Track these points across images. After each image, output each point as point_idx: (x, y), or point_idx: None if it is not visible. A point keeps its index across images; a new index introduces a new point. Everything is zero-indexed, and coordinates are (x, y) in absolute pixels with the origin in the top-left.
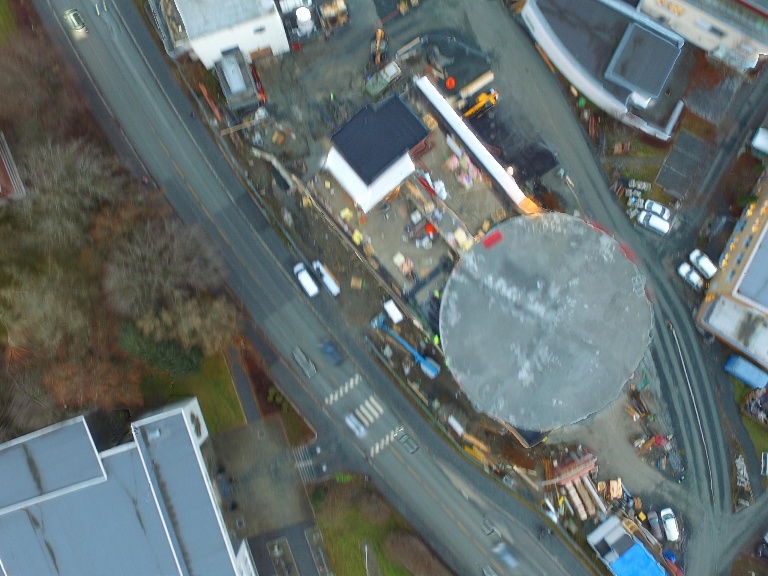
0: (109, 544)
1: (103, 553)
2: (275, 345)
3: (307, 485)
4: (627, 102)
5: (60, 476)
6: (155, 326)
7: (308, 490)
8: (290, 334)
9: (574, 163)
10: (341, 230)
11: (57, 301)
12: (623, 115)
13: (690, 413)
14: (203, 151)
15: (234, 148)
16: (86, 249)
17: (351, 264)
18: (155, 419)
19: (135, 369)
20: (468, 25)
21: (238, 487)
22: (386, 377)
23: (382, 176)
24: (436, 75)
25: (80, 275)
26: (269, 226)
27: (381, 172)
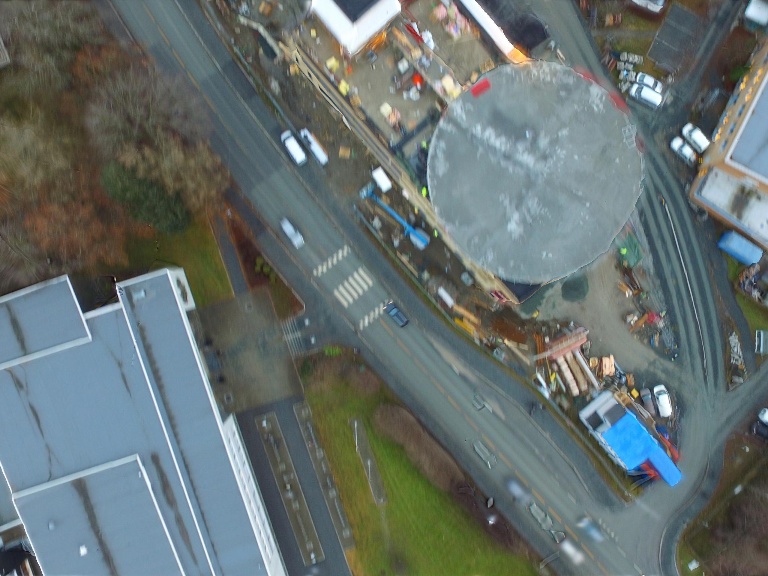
0: (94, 407)
1: (88, 416)
2: (262, 215)
3: (296, 359)
4: None
5: (44, 337)
6: (137, 161)
7: (297, 364)
8: (278, 204)
9: (565, 36)
10: (327, 79)
11: (38, 137)
12: None
13: (683, 290)
14: (189, 17)
15: (220, 14)
16: (68, 90)
17: (339, 133)
18: (140, 279)
19: (119, 221)
20: None
21: (226, 361)
22: (375, 249)
23: (367, 13)
24: None
25: (62, 119)
26: (256, 94)
27: (366, 9)
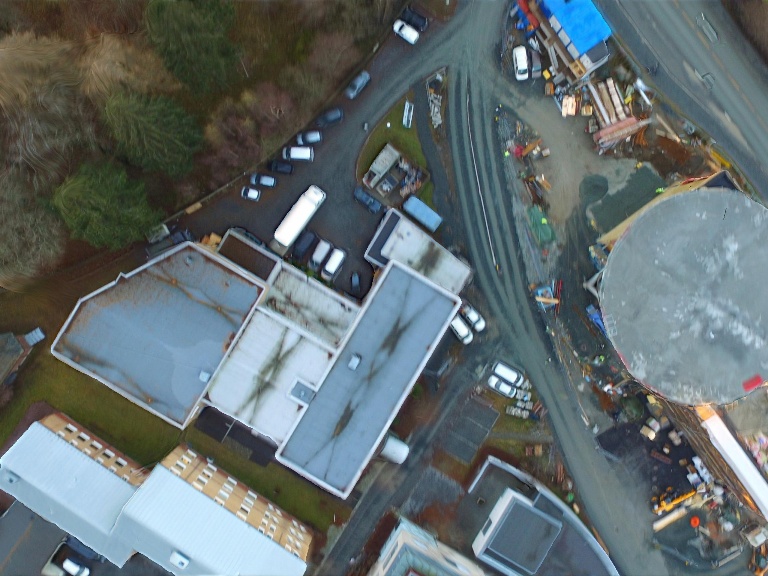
0: None
1: None
2: None
3: None
4: (538, 497)
5: None
6: None
7: None
8: None
9: (580, 438)
10: None
11: None
12: (532, 483)
13: (485, 177)
14: None
15: None
16: None
17: None
18: None
19: None
20: (672, 575)
21: None
22: None
23: None
24: (708, 530)
25: None
26: None
27: None
